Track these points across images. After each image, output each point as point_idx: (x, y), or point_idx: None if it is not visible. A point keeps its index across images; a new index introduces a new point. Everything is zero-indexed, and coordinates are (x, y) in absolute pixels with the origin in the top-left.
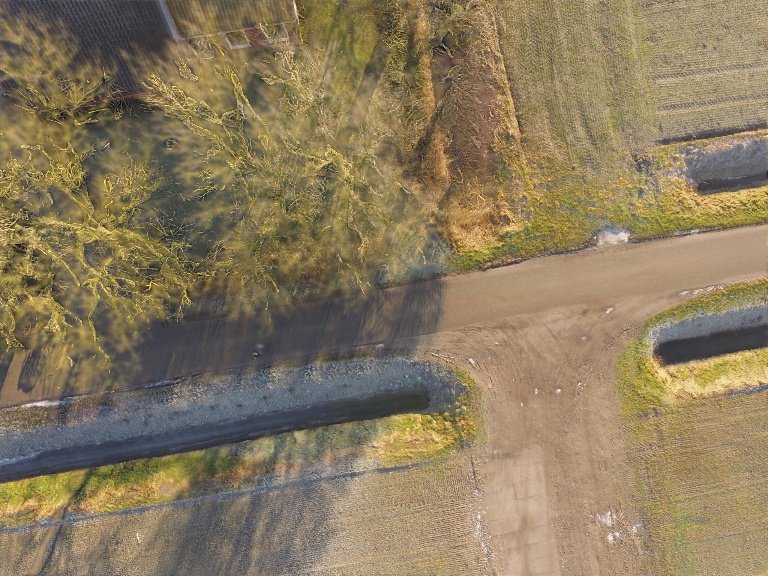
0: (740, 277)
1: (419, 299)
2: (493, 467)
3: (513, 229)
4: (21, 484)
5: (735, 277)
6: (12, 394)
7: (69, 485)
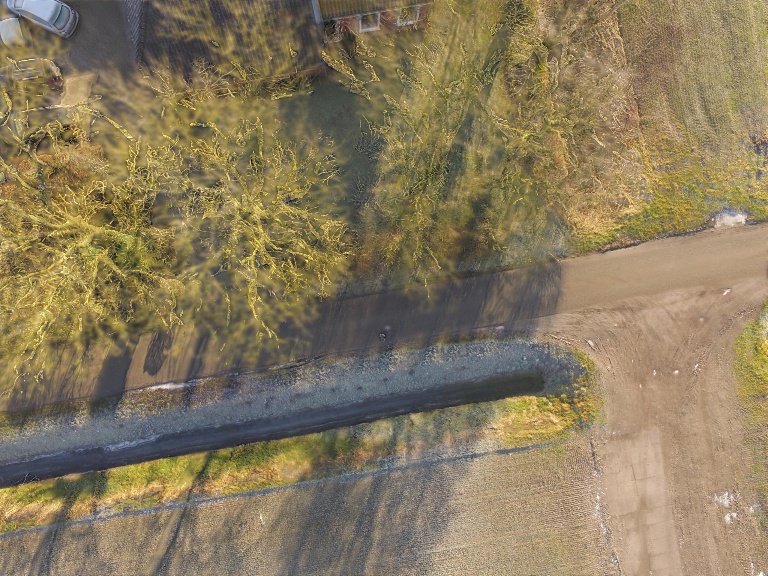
0: None
1: (539, 281)
2: (612, 448)
3: (632, 211)
4: (142, 467)
5: None
6: (138, 377)
7: (191, 467)
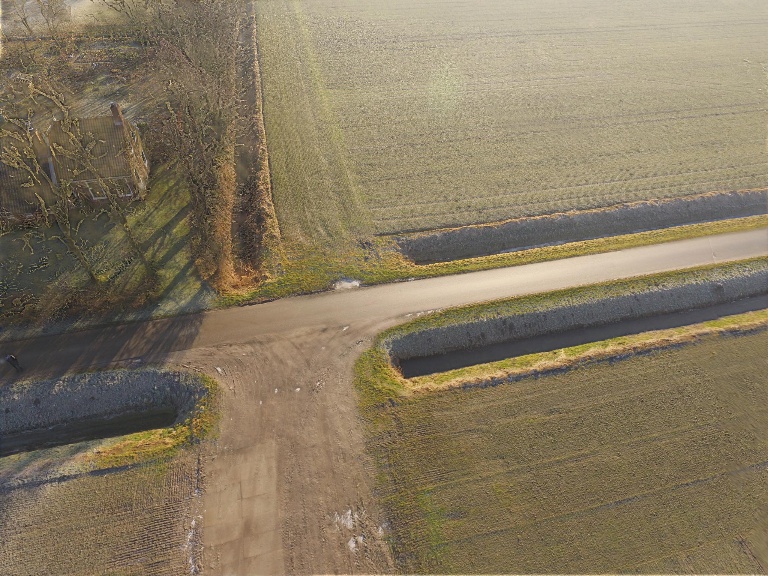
0: (452, 304)
1: (182, 326)
2: (221, 464)
3: (269, 281)
4: None
5: (448, 304)
6: None
7: None
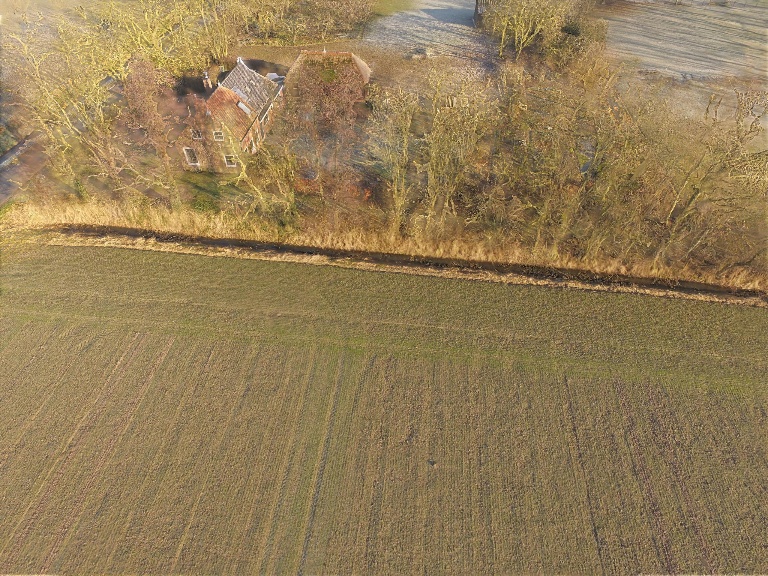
0: None
1: (12, 186)
2: None
3: None
4: None
5: None
6: None
7: None
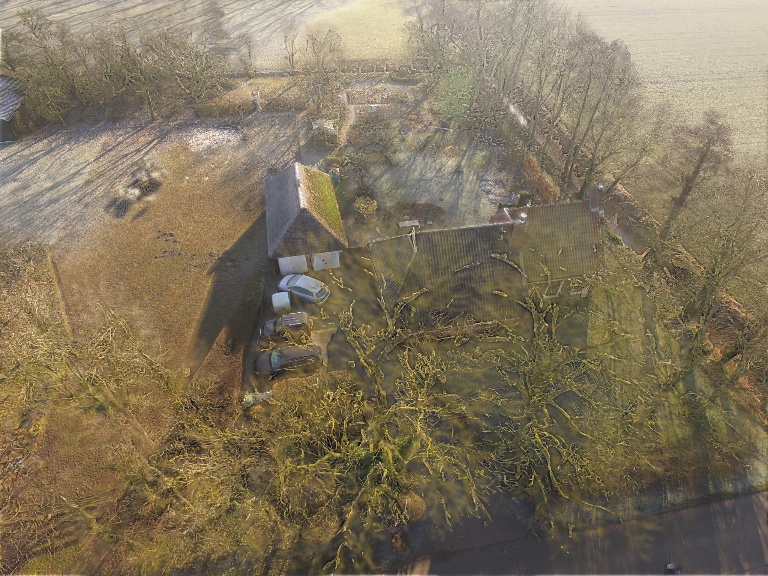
0: None
1: None
2: None
3: None
4: None
5: None
6: None
7: None
